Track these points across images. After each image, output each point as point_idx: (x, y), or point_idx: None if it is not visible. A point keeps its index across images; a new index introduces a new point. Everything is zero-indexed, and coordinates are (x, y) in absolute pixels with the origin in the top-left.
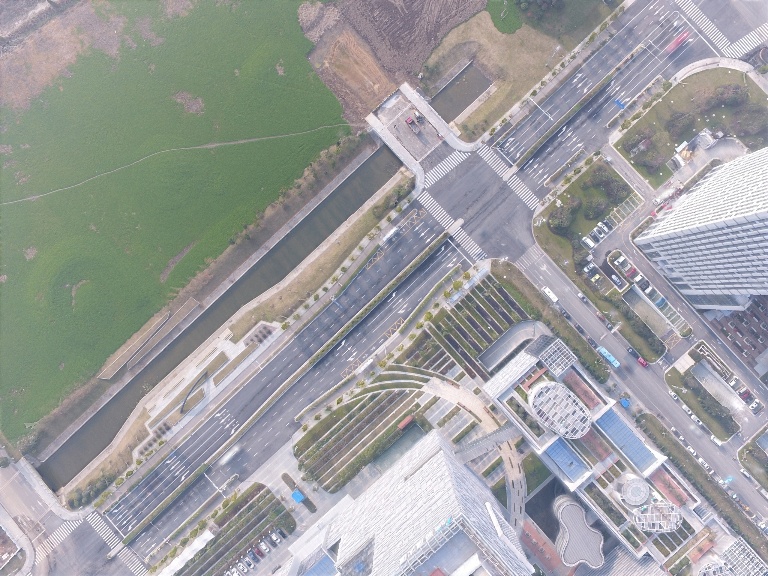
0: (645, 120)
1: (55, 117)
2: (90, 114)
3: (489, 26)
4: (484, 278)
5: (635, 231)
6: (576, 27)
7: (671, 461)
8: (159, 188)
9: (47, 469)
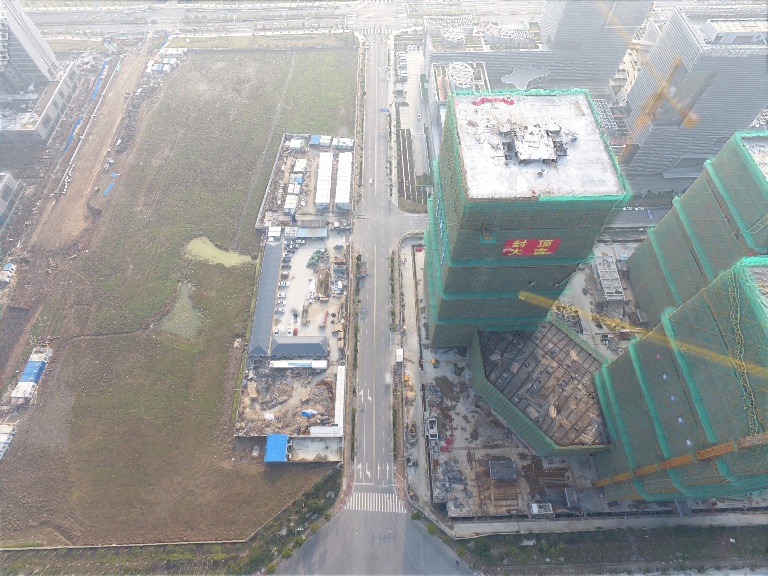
0: None
1: None
2: None
3: None
4: None
5: None
6: None
7: None
8: None
9: None
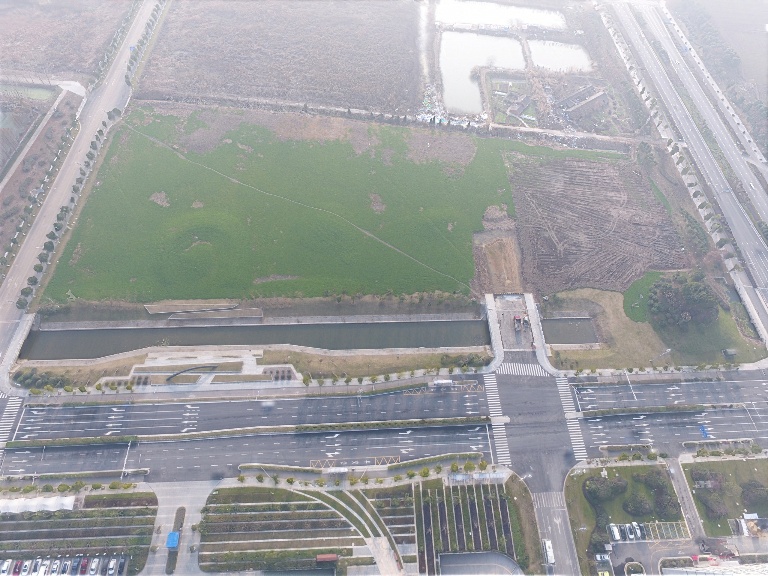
0: (722, 465)
1: (293, 155)
2: (314, 167)
3: (619, 305)
4: (496, 483)
5: (668, 560)
6: (690, 353)
7: None
8: (312, 230)
9: (36, 337)
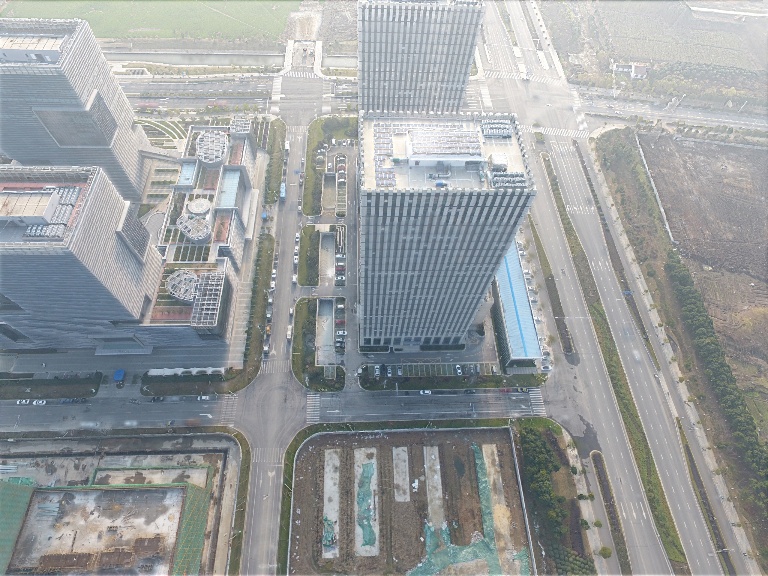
0: None
1: None
2: None
3: None
4: None
5: None
6: None
7: (256, 270)
8: (175, 7)
9: None
